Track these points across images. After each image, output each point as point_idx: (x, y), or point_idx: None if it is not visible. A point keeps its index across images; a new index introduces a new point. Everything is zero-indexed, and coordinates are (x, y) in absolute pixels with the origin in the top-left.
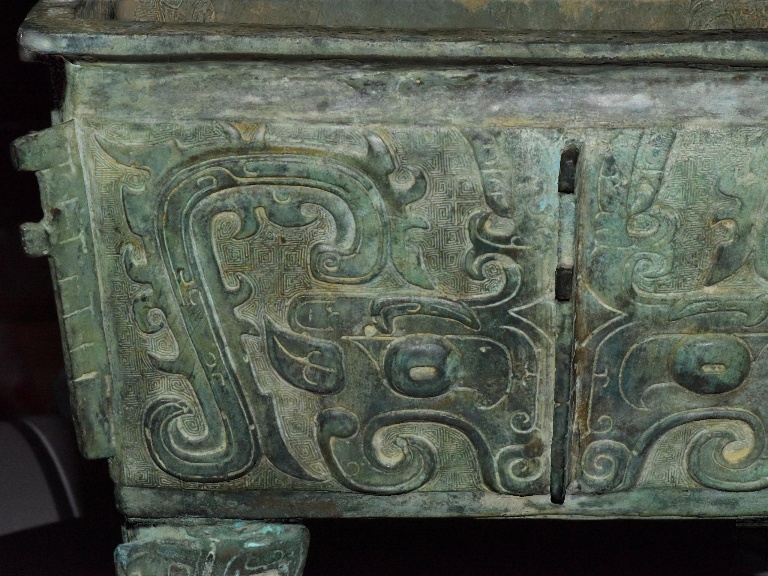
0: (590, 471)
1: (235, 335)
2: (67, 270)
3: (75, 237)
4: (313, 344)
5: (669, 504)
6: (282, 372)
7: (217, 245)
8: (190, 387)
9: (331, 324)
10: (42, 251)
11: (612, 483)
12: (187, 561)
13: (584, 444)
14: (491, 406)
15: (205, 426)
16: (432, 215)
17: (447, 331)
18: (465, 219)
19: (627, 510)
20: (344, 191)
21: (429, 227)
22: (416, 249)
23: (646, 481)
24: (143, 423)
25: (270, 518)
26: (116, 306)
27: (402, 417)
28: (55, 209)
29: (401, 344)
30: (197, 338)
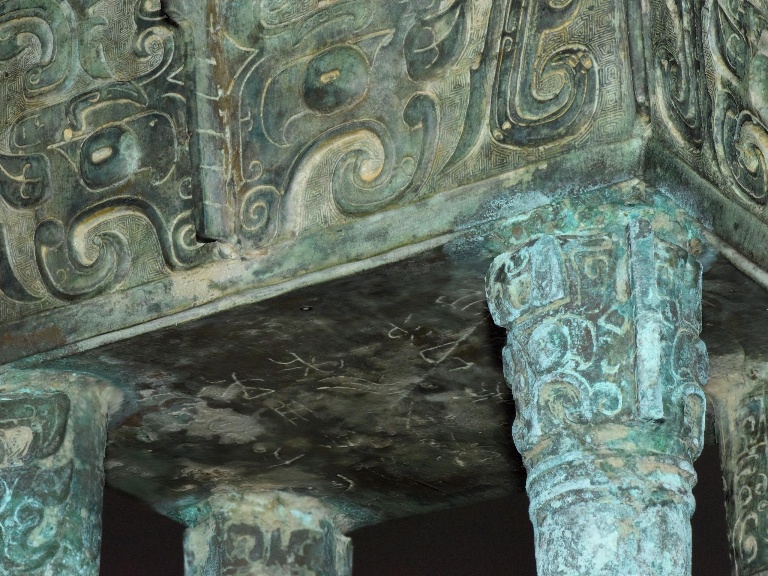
0: (248, 223)
1: None
2: None
3: None
4: (24, 158)
5: (329, 251)
6: (4, 194)
7: None
8: None
9: (39, 137)
10: None
11: (266, 229)
12: None
13: (240, 196)
14: (163, 180)
15: None
16: (110, 13)
17: (124, 115)
18: (133, 7)
19: (295, 269)
20: (43, 10)
21: (108, 24)
22: (96, 44)
23: (303, 228)
24: None
25: (12, 360)
26: None
27: (93, 209)
28: None
29: None
30: None
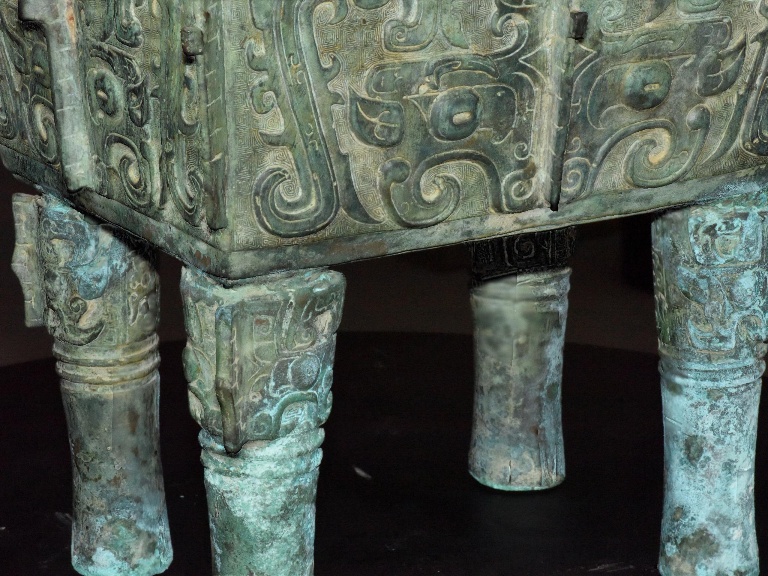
0: (565, 185)
1: (327, 106)
2: (211, 65)
3: (215, 37)
4: (385, 105)
5: (608, 206)
6: (361, 132)
7: (316, 31)
8: (290, 156)
9: (396, 87)
10: (198, 49)
11: (579, 192)
12: (270, 312)
13: None
14: (502, 141)
15: (299, 189)
16: None
17: (476, 82)
18: None
19: (580, 216)
20: None
21: None
22: (459, 16)
23: (596, 189)
24: (253, 193)
25: (336, 263)
26: (236, 94)
27: (443, 158)
28: (207, 13)
29: (445, 97)
30: (300, 112)
